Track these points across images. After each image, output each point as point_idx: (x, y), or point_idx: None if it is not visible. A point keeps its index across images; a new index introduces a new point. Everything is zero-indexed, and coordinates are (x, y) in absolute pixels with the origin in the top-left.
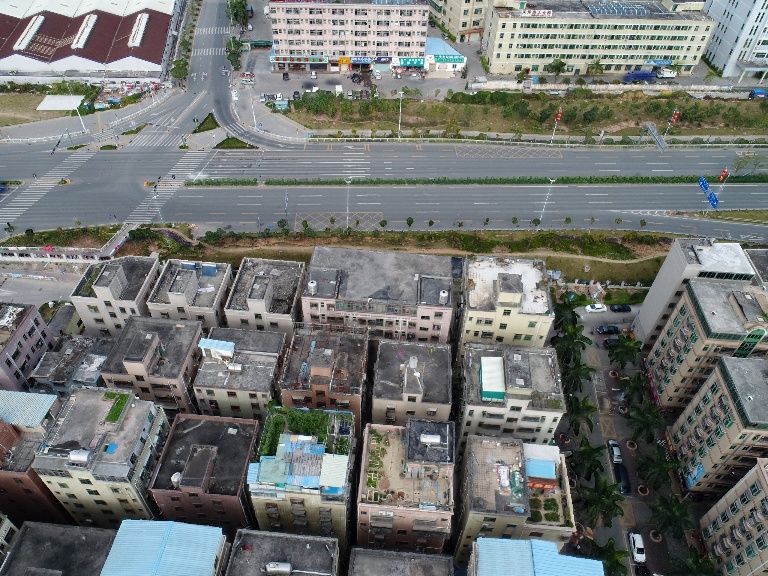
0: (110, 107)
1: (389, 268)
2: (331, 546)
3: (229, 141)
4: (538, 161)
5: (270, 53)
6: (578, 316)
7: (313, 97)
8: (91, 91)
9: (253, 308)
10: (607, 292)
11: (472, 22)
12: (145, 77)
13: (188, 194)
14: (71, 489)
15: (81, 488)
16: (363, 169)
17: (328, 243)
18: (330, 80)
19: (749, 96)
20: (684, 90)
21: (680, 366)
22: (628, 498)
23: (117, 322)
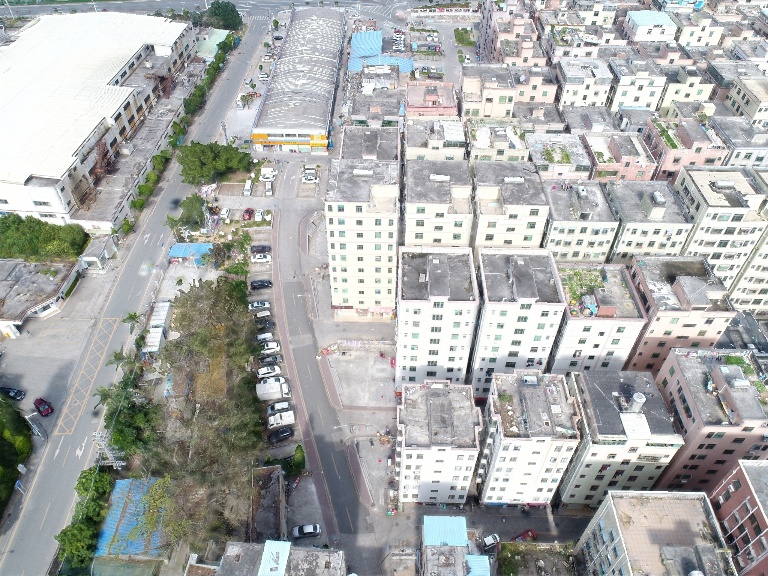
0: None
1: None
2: None
3: None
4: None
5: None
6: None
7: None
8: None
9: None
10: None
11: None
12: None
13: None
14: (585, 22)
15: (590, 20)
16: None
17: None
18: None
19: None
20: None
21: None
22: None
23: None
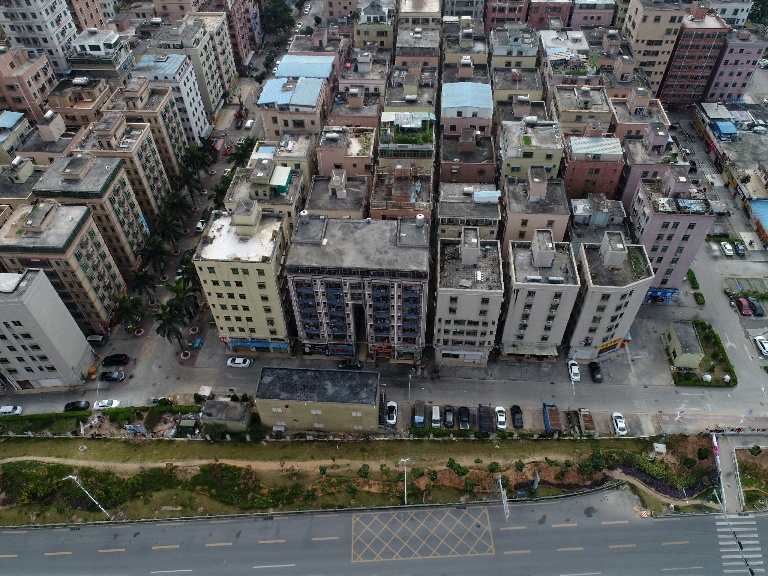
0: None
1: (350, 250)
2: None
3: None
4: None
5: None
6: None
7: None
8: None
9: None
10: None
11: None
12: None
13: None
14: None
15: None
16: None
17: None
18: None
19: None
20: None
21: None
22: None
23: None
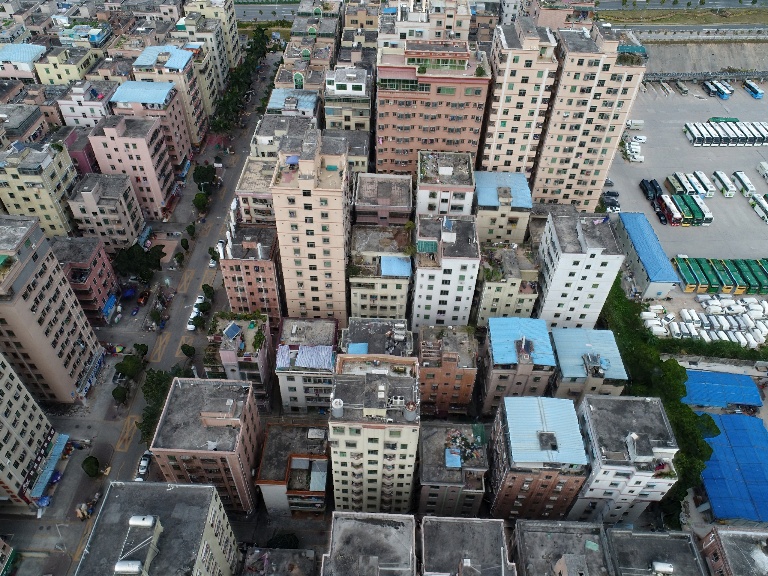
0: None
1: None
2: None
3: None
4: None
5: None
6: (266, 36)
7: None
8: None
9: (83, 13)
10: None
11: None
12: None
13: None
14: None
15: None
16: None
17: None
18: None
19: None
20: None
21: None
22: None
23: None
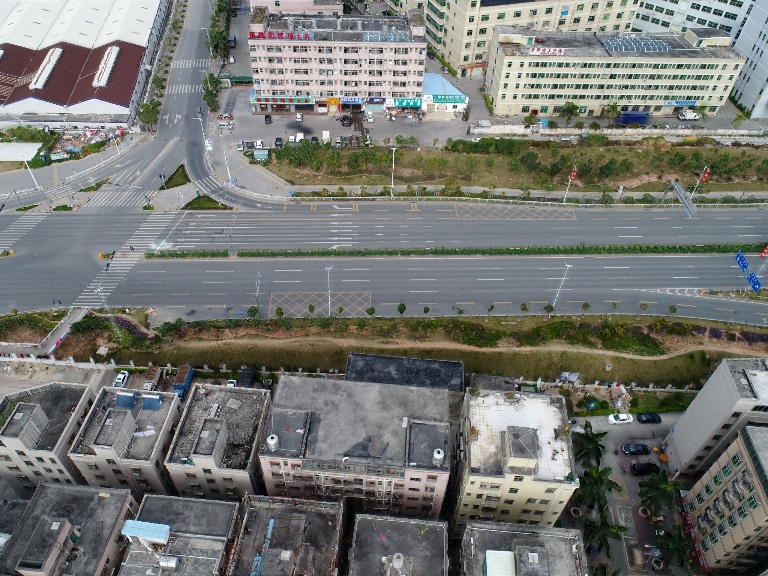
0: (69, 157)
1: (371, 408)
2: None
3: (200, 200)
4: (549, 224)
5: (251, 93)
6: (602, 447)
7: (296, 148)
8: (49, 138)
9: (200, 463)
10: (632, 396)
11: (474, 56)
12: (110, 121)
13: (148, 268)
14: None
15: None
16: (350, 235)
17: (306, 335)
18: (317, 123)
19: None
20: (709, 135)
21: (733, 529)
22: None
23: (35, 470)
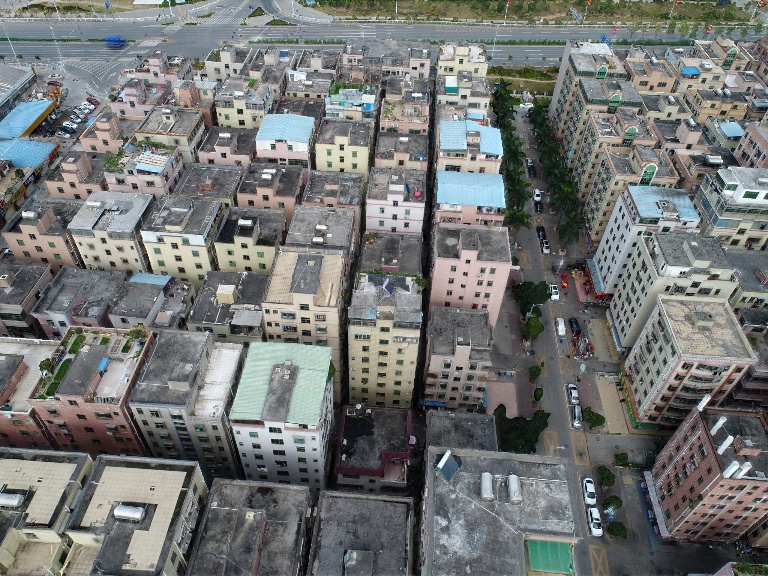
0: (186, 2)
1: (393, 46)
2: (368, 125)
3: (275, 21)
4: (494, 34)
5: None
6: None
7: None
8: None
9: (314, 65)
10: None
11: None
12: None
13: None
14: (230, 121)
15: (236, 119)
16: (371, 37)
17: None
18: None
19: (653, 1)
20: None
21: (566, 105)
22: (535, 180)
23: None
